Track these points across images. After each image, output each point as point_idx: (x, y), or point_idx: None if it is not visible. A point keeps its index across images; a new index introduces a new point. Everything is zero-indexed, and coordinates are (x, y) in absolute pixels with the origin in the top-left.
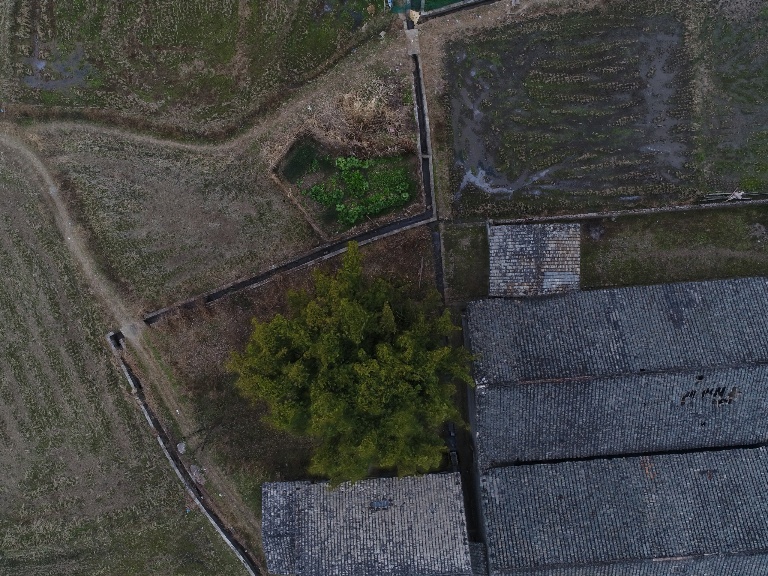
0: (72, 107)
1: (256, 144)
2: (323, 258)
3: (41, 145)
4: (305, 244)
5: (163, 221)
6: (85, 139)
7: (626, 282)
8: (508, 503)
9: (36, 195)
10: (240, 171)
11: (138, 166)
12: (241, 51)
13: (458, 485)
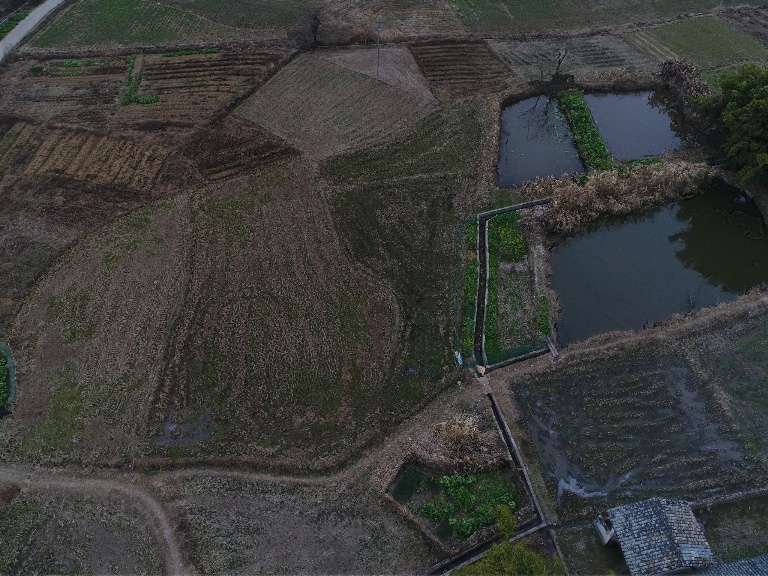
0: (196, 457)
1: (366, 472)
2: (444, 575)
3: (164, 490)
4: (423, 563)
5: (276, 554)
6: (205, 483)
7: None
8: None
9: (150, 539)
10: (352, 498)
11: (254, 503)
12: (346, 403)
13: None
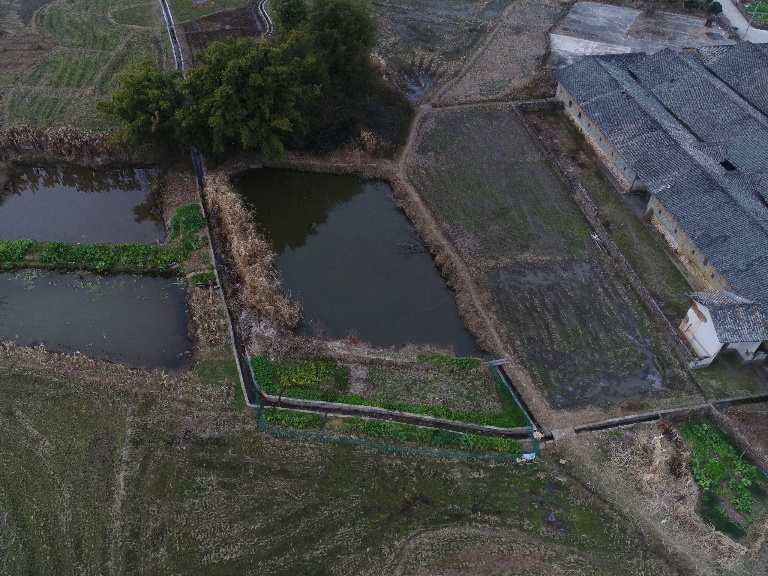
0: None
1: None
2: None
3: None
4: None
5: None
6: None
7: (685, 286)
8: None
9: None
10: None
11: None
12: None
13: None
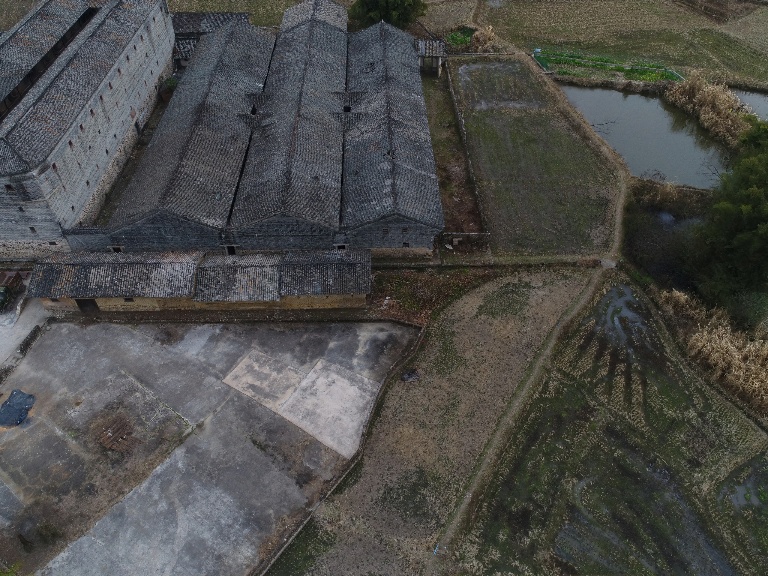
0: None
1: None
2: None
3: None
4: None
5: None
6: None
7: None
8: (335, 33)
9: None
10: None
11: None
12: None
13: (343, 29)
